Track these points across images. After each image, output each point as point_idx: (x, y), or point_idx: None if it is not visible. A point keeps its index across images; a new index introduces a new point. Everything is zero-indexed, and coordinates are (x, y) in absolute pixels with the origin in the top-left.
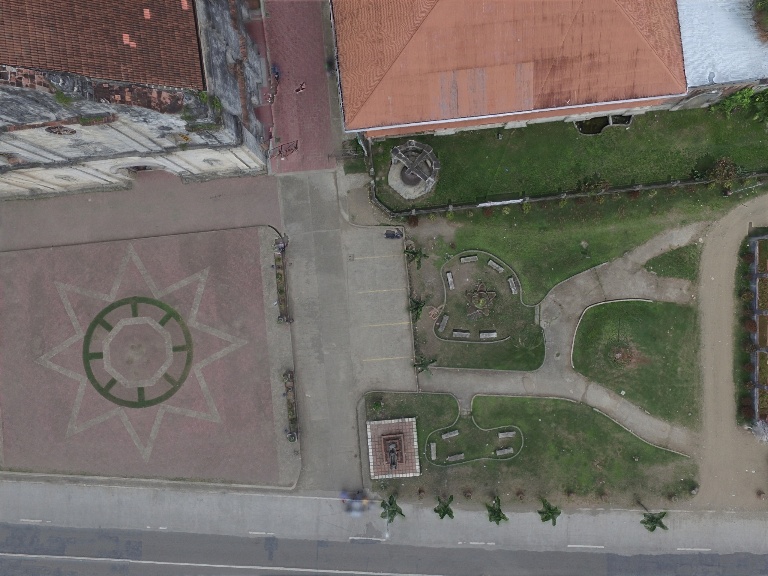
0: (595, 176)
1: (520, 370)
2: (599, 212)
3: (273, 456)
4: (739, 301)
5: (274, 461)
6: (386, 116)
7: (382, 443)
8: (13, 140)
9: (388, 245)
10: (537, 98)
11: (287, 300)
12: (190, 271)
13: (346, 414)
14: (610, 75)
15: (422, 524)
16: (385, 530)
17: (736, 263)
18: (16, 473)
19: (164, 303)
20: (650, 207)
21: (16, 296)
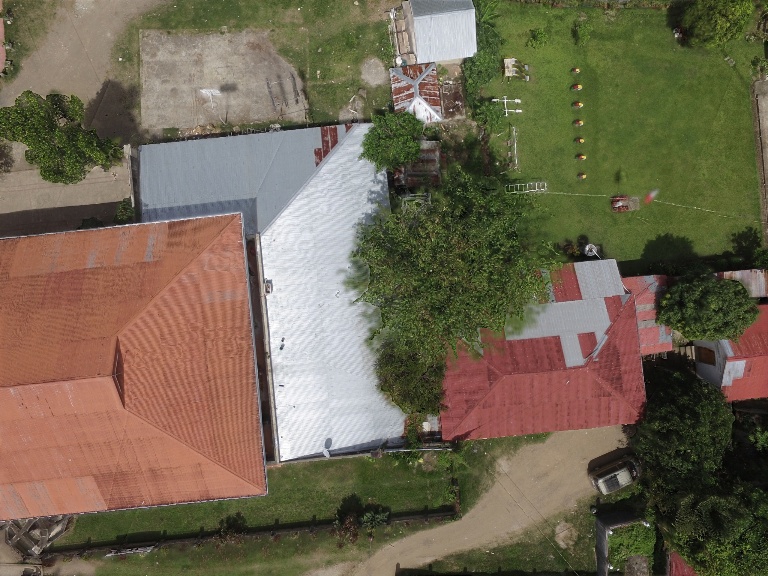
0: (238, 515)
1: None
2: (243, 551)
3: None
4: None
5: None
6: None
7: None
8: None
9: None
10: (109, 501)
11: None
12: None
13: None
14: (179, 483)
15: None
16: None
17: None
18: None
19: None
20: (296, 546)
21: None
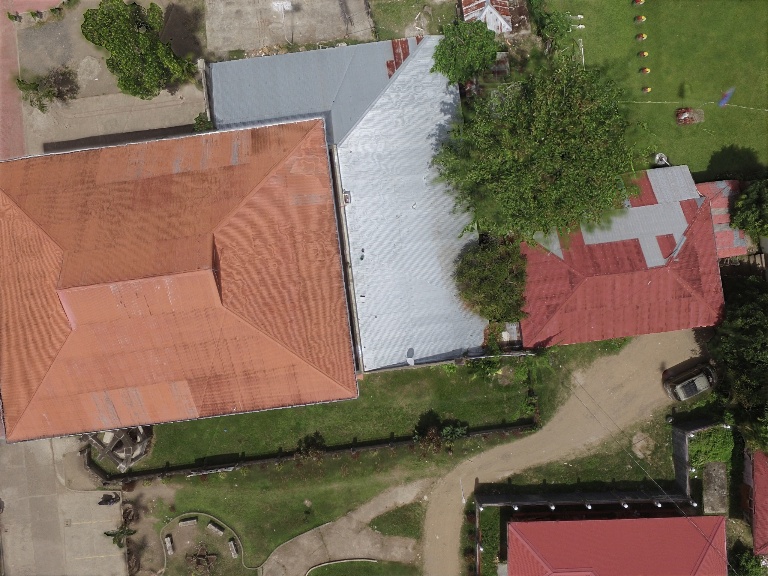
0: (316, 435)
1: None
2: (322, 470)
3: None
4: (464, 560)
5: None
6: (46, 429)
7: None
8: None
9: (105, 509)
10: (201, 408)
11: (2, 569)
12: None
13: None
14: (271, 386)
15: None
16: None
17: (461, 521)
18: None
19: None
20: (374, 464)
21: None
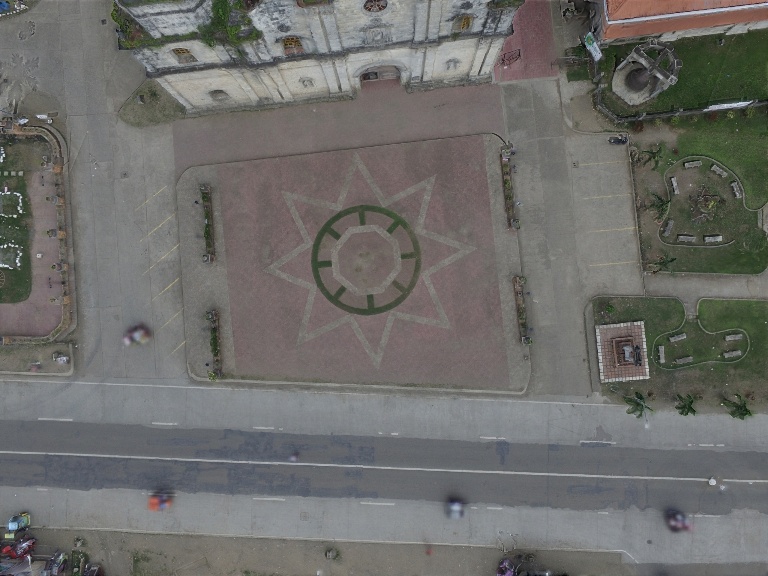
0: None
1: (745, 273)
2: None
3: (503, 361)
4: None
5: (504, 366)
6: (651, 6)
7: (614, 346)
8: (330, 14)
9: (612, 151)
10: None
11: (514, 207)
12: (417, 179)
13: (574, 319)
14: None
15: (651, 427)
16: (615, 433)
17: None
18: (248, 381)
19: (391, 211)
20: None
21: (244, 206)
